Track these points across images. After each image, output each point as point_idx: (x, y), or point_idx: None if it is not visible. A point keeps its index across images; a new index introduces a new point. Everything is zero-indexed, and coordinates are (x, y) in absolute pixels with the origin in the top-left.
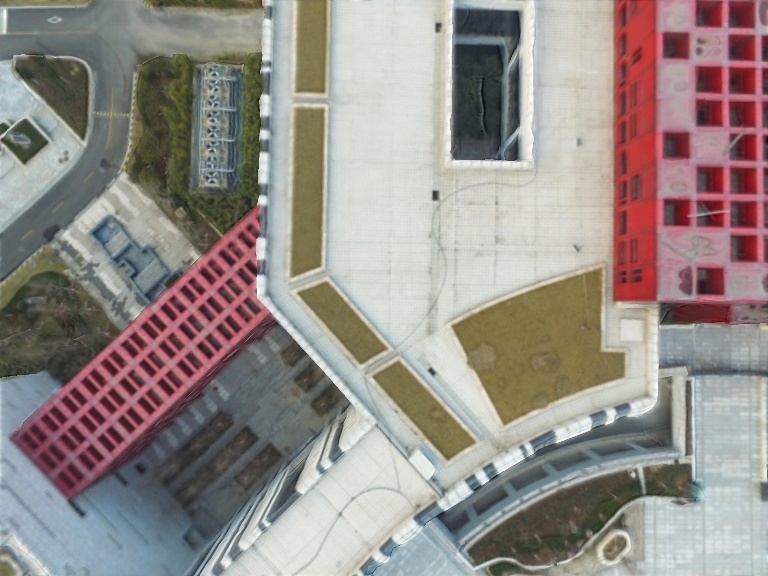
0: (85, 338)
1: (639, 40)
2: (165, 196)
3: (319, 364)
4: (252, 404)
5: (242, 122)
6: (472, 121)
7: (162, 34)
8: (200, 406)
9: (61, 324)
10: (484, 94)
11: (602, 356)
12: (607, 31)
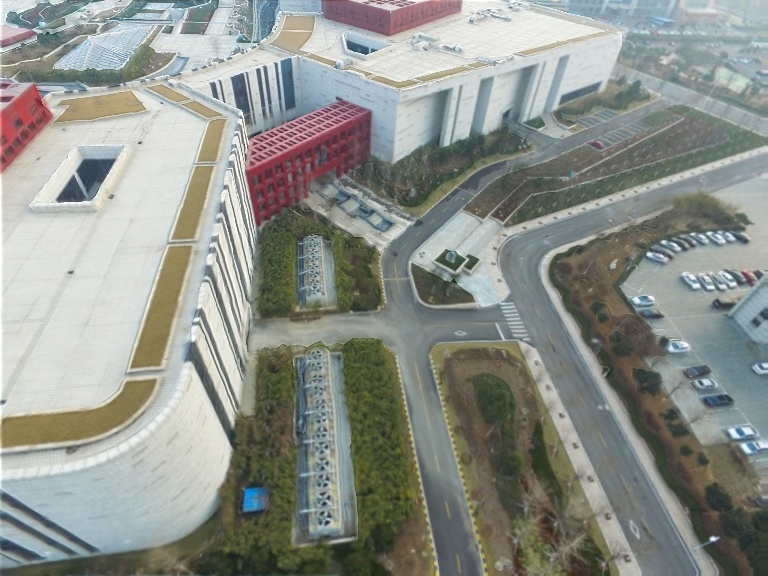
0: (369, 166)
1: None
2: None
3: None
4: None
5: None
6: None
7: (370, 329)
8: None
9: None
10: None
11: (70, 104)
12: None
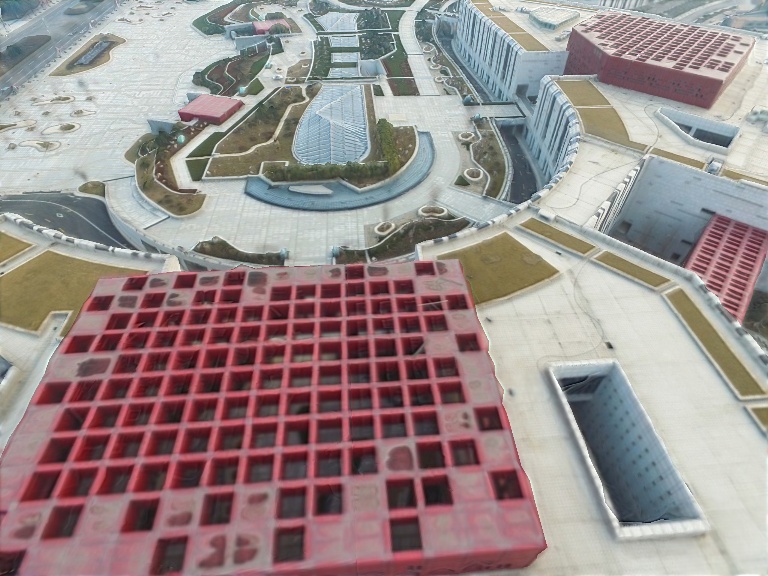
0: None
1: None
2: None
3: None
4: None
5: None
6: None
7: None
8: None
9: None
10: None
11: None
12: None
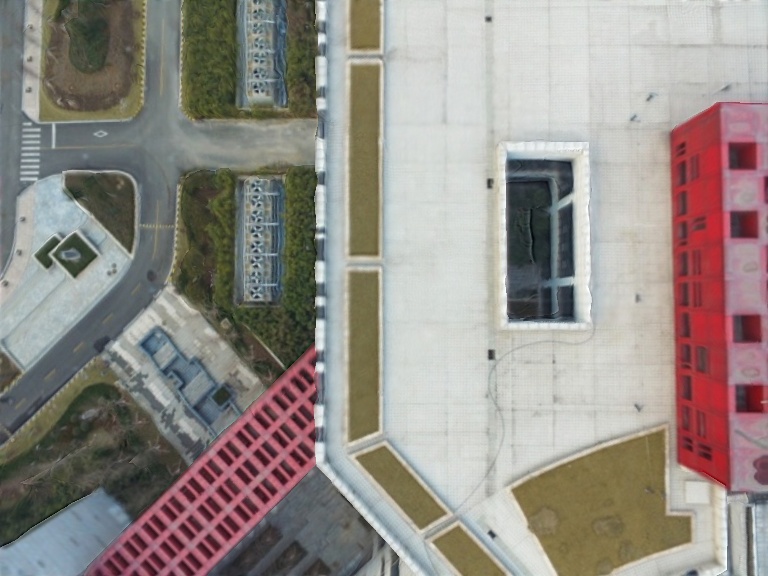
0: (139, 460)
1: (702, 208)
2: (210, 308)
3: (379, 532)
4: (300, 518)
5: (285, 236)
6: (520, 252)
7: (204, 145)
8: None
9: (113, 437)
10: (533, 227)
11: (667, 520)
12: (664, 182)
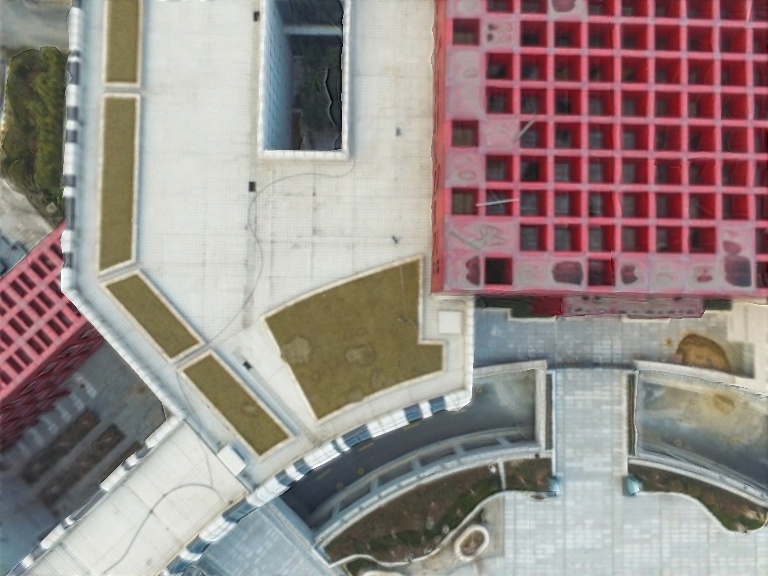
0: None
1: (441, 27)
2: (35, 191)
3: (125, 358)
4: (120, 401)
5: None
6: (319, 112)
7: (35, 27)
8: (66, 404)
9: None
10: (328, 85)
11: (419, 349)
12: (428, 19)
